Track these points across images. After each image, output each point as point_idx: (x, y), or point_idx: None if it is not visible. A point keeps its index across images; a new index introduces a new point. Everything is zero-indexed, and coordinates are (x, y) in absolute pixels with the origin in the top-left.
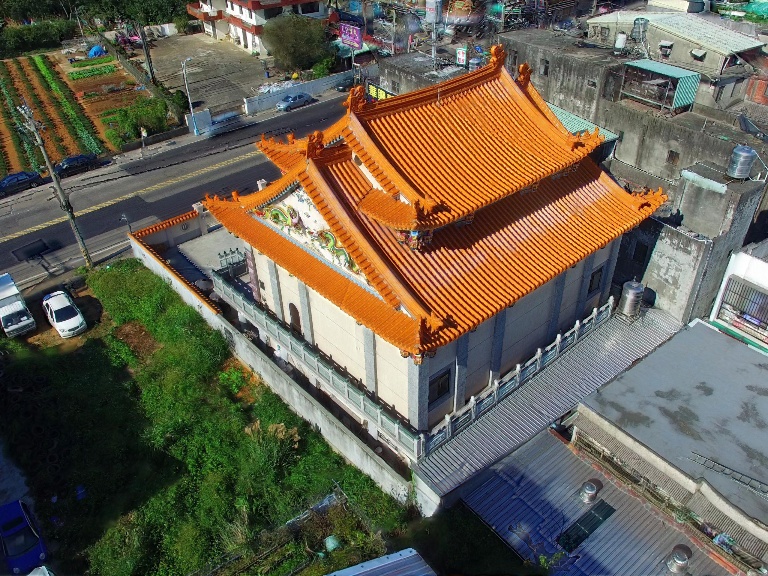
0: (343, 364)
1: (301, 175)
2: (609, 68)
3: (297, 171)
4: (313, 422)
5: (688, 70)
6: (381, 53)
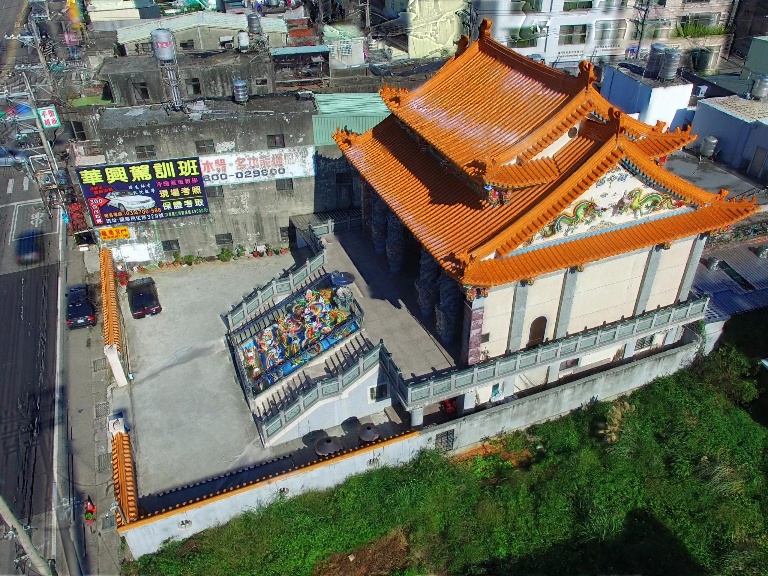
0: None
1: None
2: (274, 62)
3: (603, 156)
4: None
5: None
6: (18, 137)
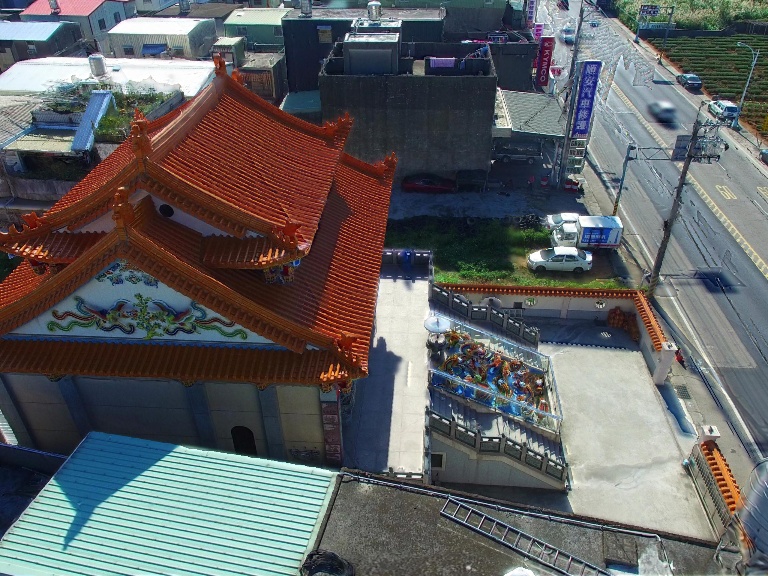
0: None
1: None
2: None
3: None
4: None
5: None
6: None
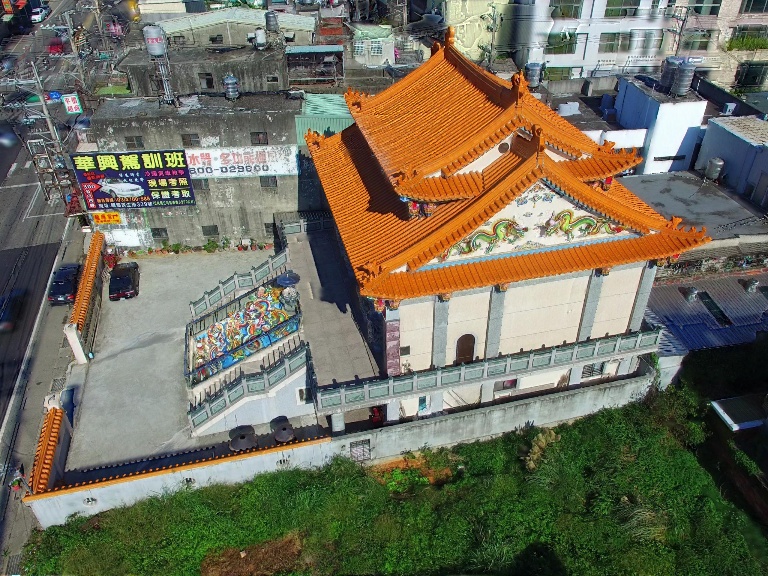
0: (540, 345)
1: (545, 171)
2: (285, 60)
3: (522, 174)
4: (522, 425)
5: (331, 45)
6: (26, 122)
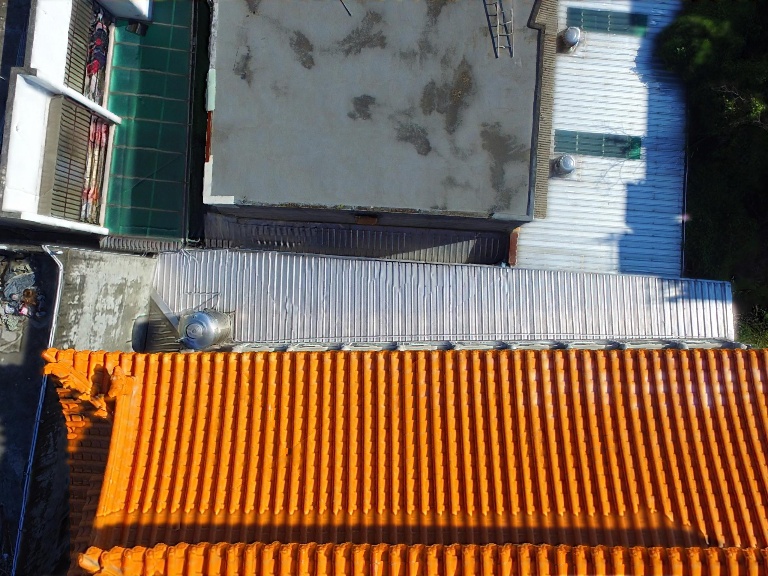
0: None
1: None
2: None
3: None
4: None
5: None
6: None
